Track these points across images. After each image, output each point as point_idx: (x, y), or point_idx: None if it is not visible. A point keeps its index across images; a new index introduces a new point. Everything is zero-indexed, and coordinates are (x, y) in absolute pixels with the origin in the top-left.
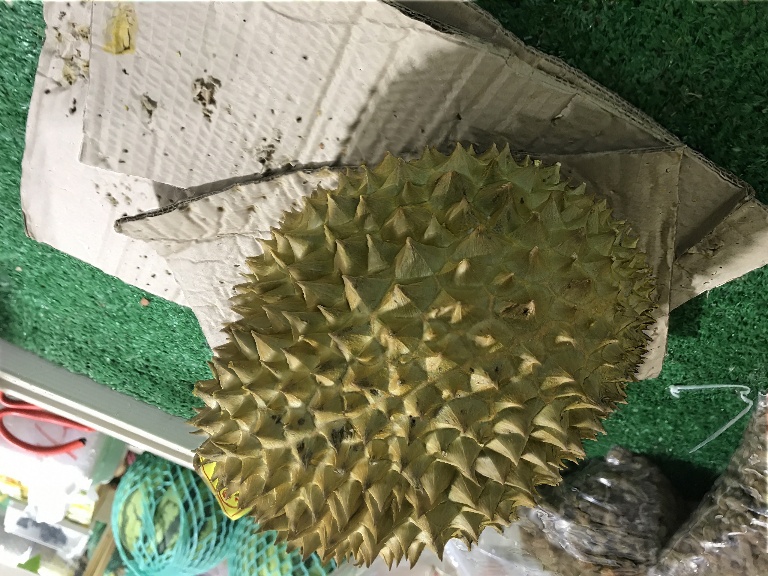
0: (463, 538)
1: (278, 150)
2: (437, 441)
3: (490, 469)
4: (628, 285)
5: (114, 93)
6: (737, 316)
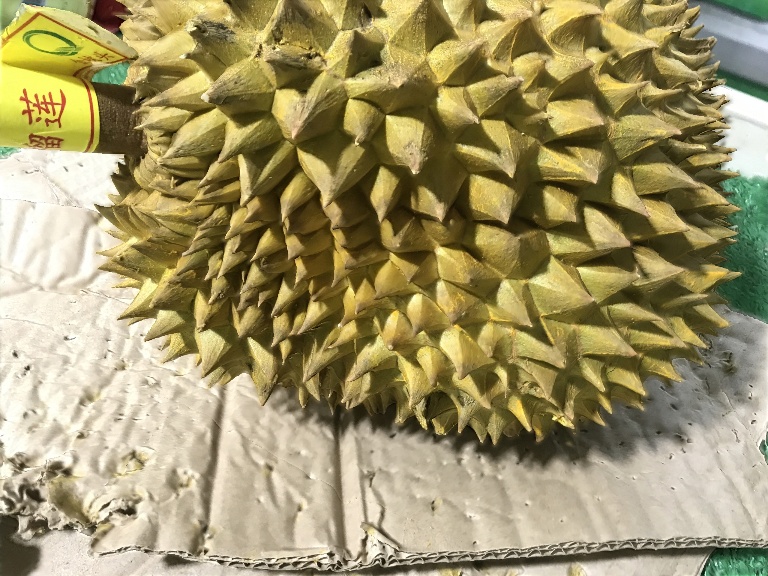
0: None
1: None
2: None
3: None
4: None
5: None
6: None
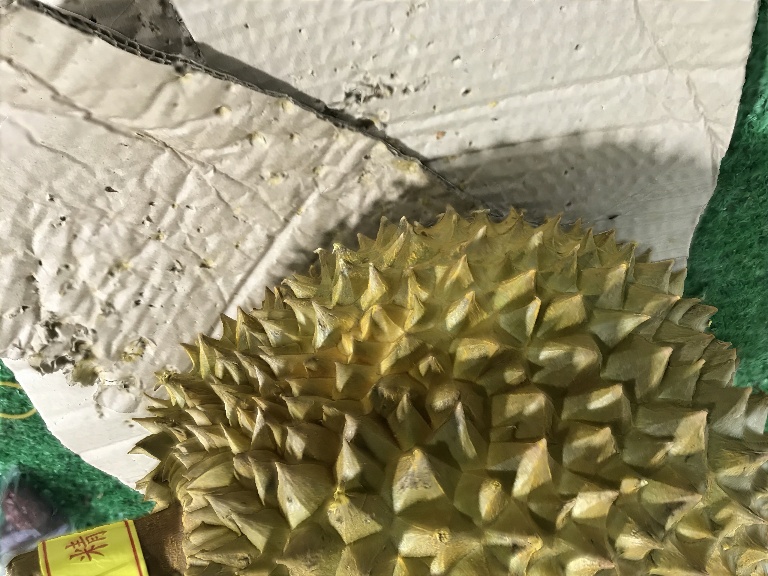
0: None
1: (389, 99)
2: None
3: None
4: None
5: None
6: None
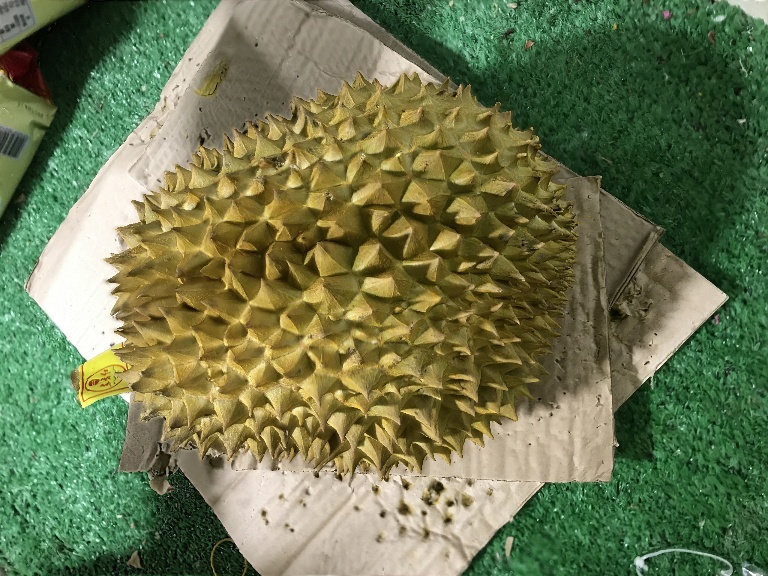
0: (355, 354)
1: None
2: (359, 156)
3: (402, 224)
4: (545, 163)
5: (184, 124)
6: (689, 427)
